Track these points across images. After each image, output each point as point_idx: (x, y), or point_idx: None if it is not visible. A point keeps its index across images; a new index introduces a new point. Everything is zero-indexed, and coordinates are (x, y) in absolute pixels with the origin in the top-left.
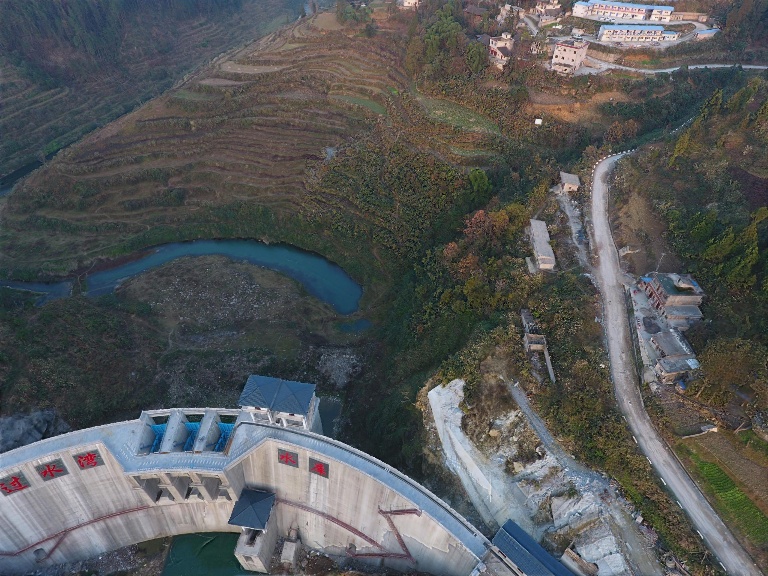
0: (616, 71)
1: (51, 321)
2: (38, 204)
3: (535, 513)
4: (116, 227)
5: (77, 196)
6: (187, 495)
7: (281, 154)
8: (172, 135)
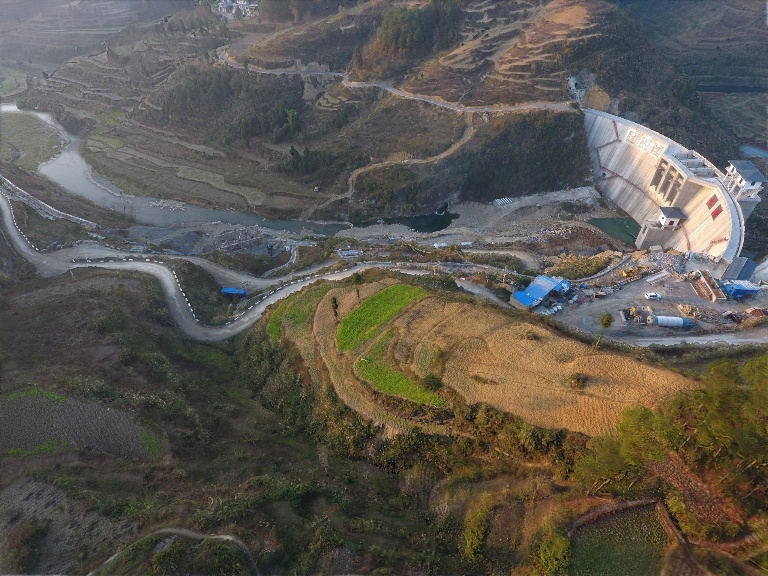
0: None
1: (708, 129)
2: None
3: None
4: None
5: None
6: None
7: None
8: None
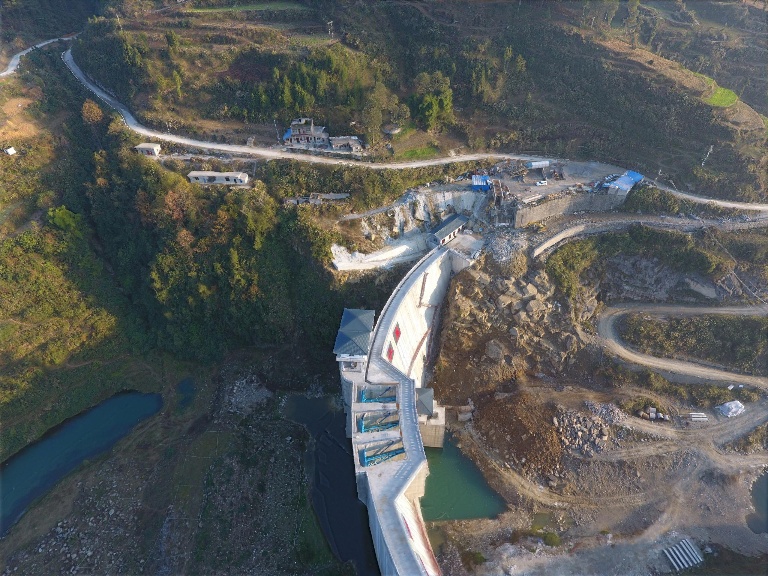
0: None
1: None
2: None
3: (420, 229)
4: None
5: None
6: None
7: None
8: None
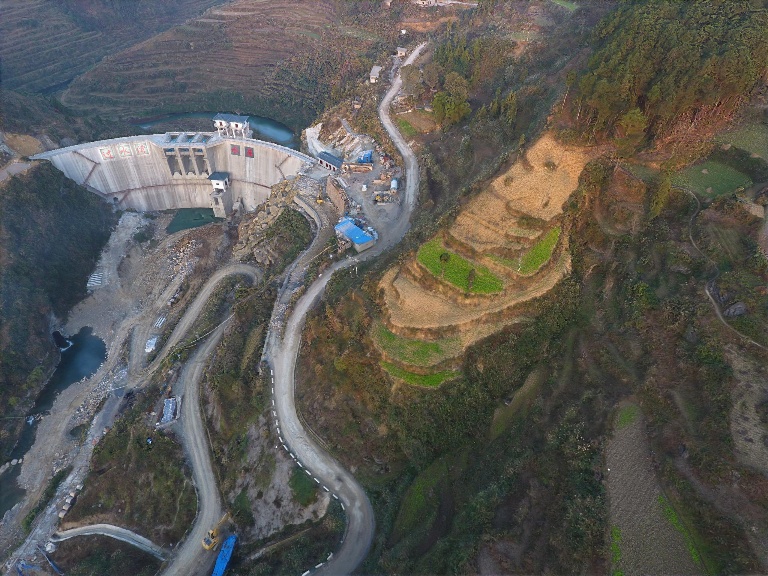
0: (455, 4)
1: None
2: (91, 89)
3: (340, 155)
4: (142, 102)
5: (117, 83)
6: (187, 173)
7: (250, 63)
8: (178, 51)
